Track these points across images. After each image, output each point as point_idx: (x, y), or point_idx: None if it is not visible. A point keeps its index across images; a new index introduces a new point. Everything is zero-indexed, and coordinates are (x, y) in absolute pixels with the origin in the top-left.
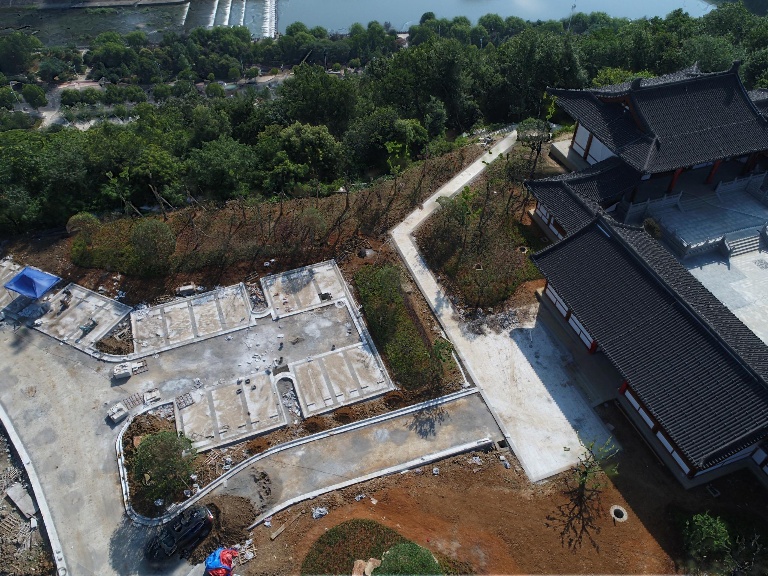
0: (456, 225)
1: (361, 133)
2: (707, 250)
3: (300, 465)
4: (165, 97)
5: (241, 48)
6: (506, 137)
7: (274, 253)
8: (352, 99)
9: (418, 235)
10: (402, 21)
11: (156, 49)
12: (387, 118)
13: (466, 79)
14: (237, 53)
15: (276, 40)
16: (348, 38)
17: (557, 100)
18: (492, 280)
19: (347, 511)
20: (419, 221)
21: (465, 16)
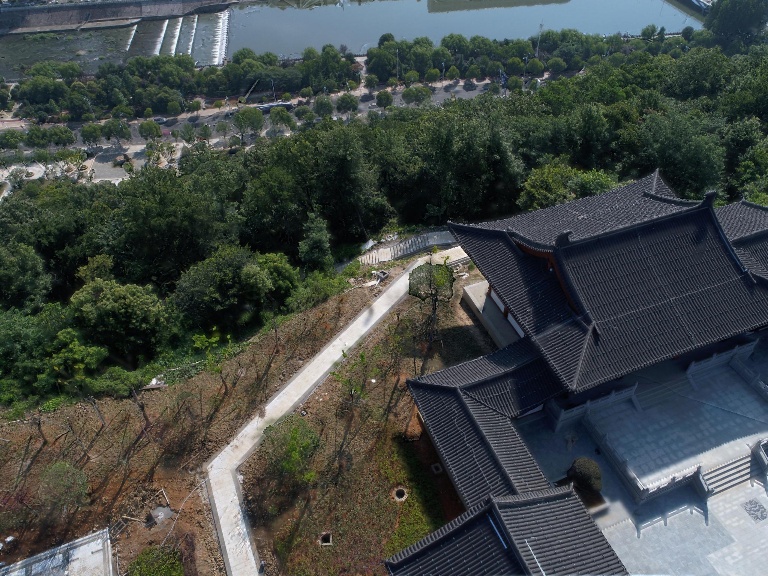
0: None
1: (191, 290)
2: (674, 488)
3: None
4: (94, 138)
5: (183, 78)
6: (406, 271)
7: (13, 526)
8: (202, 220)
9: (247, 472)
10: (359, 43)
11: (89, 82)
12: (230, 265)
13: (367, 175)
14: (178, 84)
15: (221, 69)
16: (301, 64)
17: (461, 242)
18: (342, 569)
19: None
20: (254, 442)
21: (427, 36)
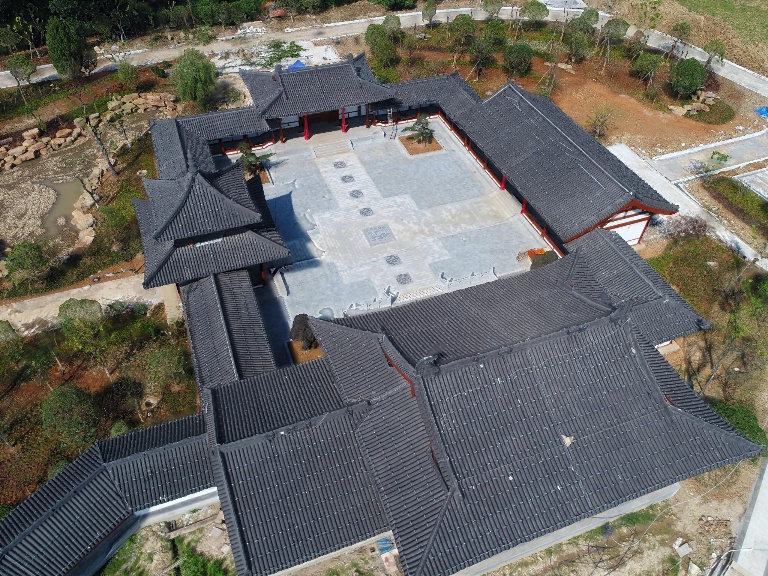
0: (764, 309)
1: None
2: None
3: (767, 147)
4: None
5: None
6: None
7: None
8: None
9: None
10: None
11: None
12: None
13: None
14: None
15: None
16: None
17: None
18: None
19: (725, 128)
20: None
21: None
